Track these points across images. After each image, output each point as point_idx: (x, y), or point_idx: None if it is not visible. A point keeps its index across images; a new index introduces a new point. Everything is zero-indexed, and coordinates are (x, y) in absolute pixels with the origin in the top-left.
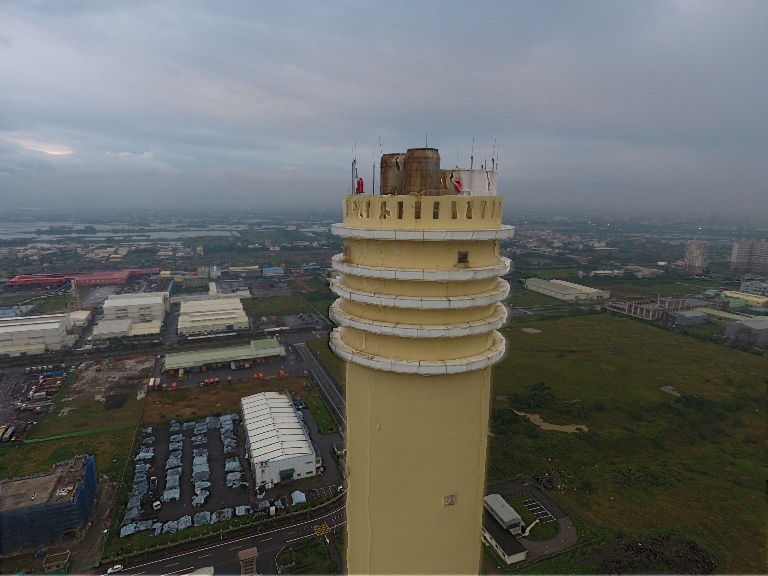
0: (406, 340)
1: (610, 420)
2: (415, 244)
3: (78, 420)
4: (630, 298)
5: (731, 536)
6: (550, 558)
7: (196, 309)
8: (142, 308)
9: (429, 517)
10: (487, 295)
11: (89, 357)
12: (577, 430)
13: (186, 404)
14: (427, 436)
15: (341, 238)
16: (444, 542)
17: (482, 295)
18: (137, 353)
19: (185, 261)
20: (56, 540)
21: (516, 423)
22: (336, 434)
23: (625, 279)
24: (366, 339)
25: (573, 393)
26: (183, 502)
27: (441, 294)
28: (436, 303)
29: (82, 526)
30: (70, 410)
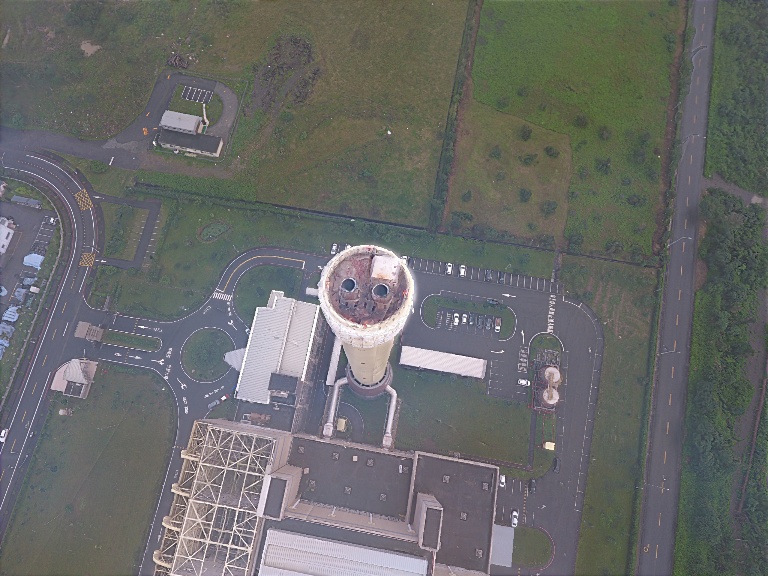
0: None
1: None
2: None
3: None
4: None
5: (305, 8)
6: (235, 128)
7: None
8: None
9: None
10: None
11: None
12: None
13: None
14: None
15: None
16: None
17: None
18: None
19: None
20: None
21: (101, 12)
22: None
23: None
24: None
25: None
26: None
27: None
28: None
29: None
30: None
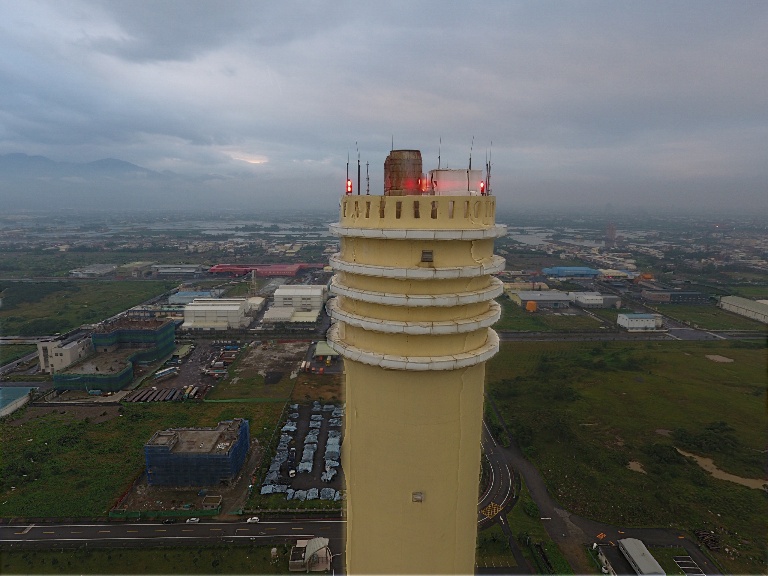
0: (372, 333)
1: None
2: (380, 242)
3: (243, 389)
4: None
5: None
6: None
7: None
8: (304, 298)
9: (398, 509)
10: (453, 296)
11: (259, 337)
12: (765, 487)
13: (329, 388)
14: (395, 429)
15: None
16: (414, 538)
17: (447, 295)
18: (296, 338)
19: None
20: (214, 485)
21: (678, 464)
22: None
23: None
24: (346, 330)
25: (767, 441)
26: (314, 475)
27: (403, 291)
28: (394, 299)
29: (234, 478)
30: (239, 380)
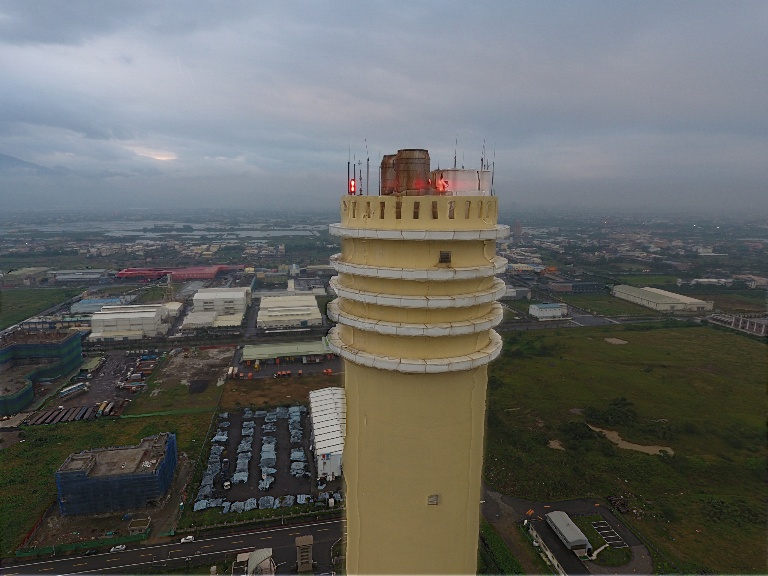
0: (387, 337)
1: (702, 445)
2: (396, 243)
3: (166, 401)
4: (738, 310)
5: None
6: None
7: (274, 304)
8: (226, 302)
9: (413, 514)
10: (470, 296)
11: (179, 344)
12: (660, 452)
13: (259, 393)
14: (410, 433)
15: None
16: (429, 541)
17: (465, 296)
18: (220, 343)
19: (267, 259)
20: (140, 507)
21: (590, 439)
22: None
23: (734, 289)
24: (354, 335)
25: (659, 412)
26: (250, 485)
27: (421, 293)
28: (414, 302)
29: (162, 497)
30: (160, 391)
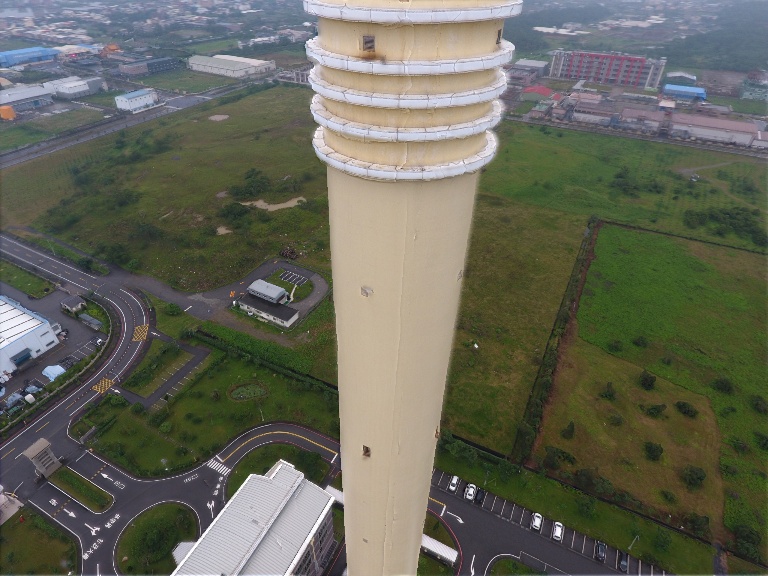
0: (456, 141)
1: (319, 186)
2: (473, 26)
3: None
4: (295, 65)
5: None
6: (315, 308)
7: None
8: None
9: (449, 294)
10: None
11: None
12: (298, 202)
13: None
14: (454, 229)
15: (365, 26)
16: (452, 308)
17: (503, 78)
18: None
19: None
20: None
21: (246, 214)
22: (56, 292)
23: (282, 45)
24: (408, 151)
25: (282, 171)
26: None
27: (487, 83)
28: (489, 94)
29: None
30: None
